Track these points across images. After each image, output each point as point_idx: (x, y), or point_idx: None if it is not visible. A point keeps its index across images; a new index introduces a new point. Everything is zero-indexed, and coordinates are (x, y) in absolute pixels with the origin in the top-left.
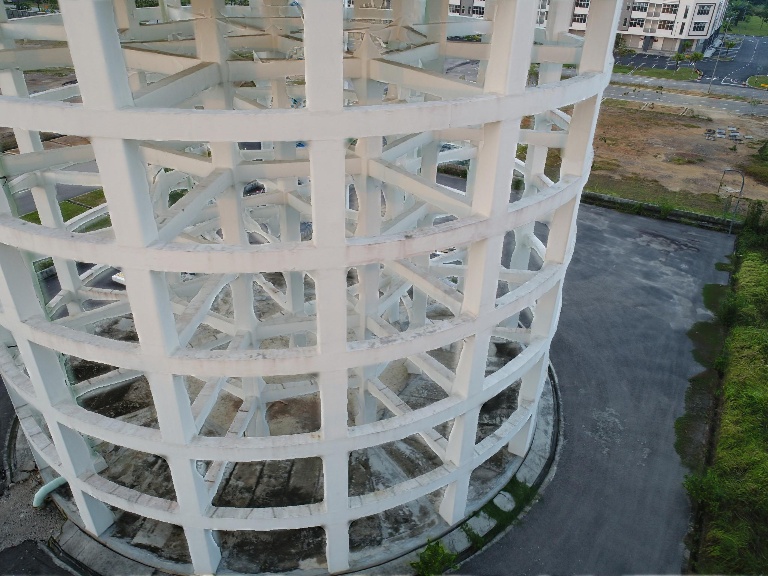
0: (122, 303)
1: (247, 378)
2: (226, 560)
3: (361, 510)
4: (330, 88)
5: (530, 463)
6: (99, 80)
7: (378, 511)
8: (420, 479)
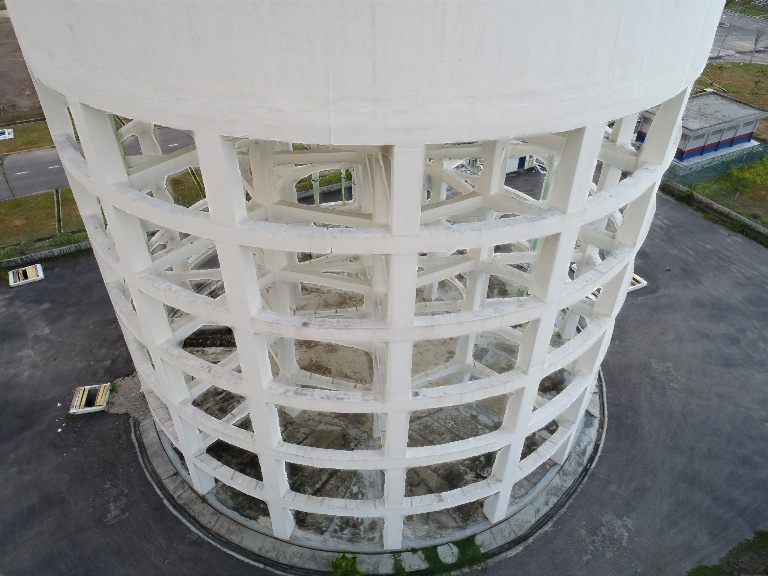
0: None
1: (281, 360)
2: (217, 488)
3: (292, 504)
4: (223, 209)
5: (497, 532)
6: (96, 166)
7: (307, 511)
8: (349, 502)
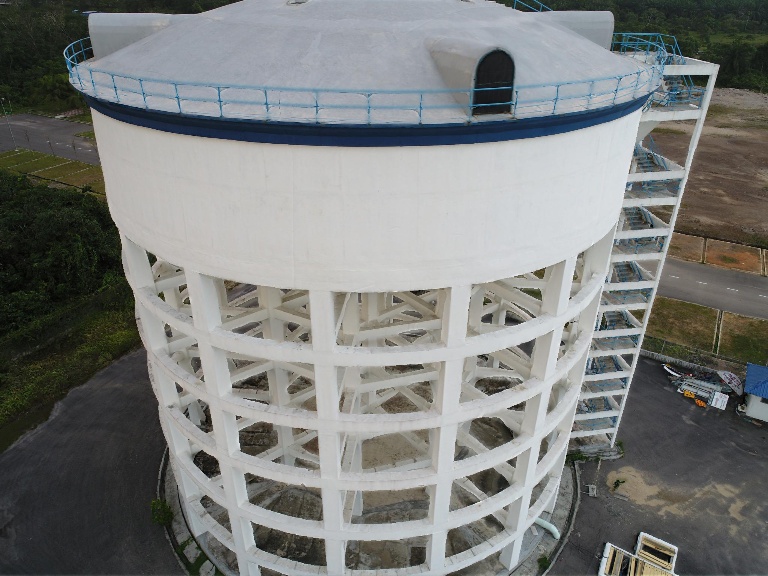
0: (301, 309)
1: None
2: None
3: None
4: None
5: None
6: None
7: None
8: None
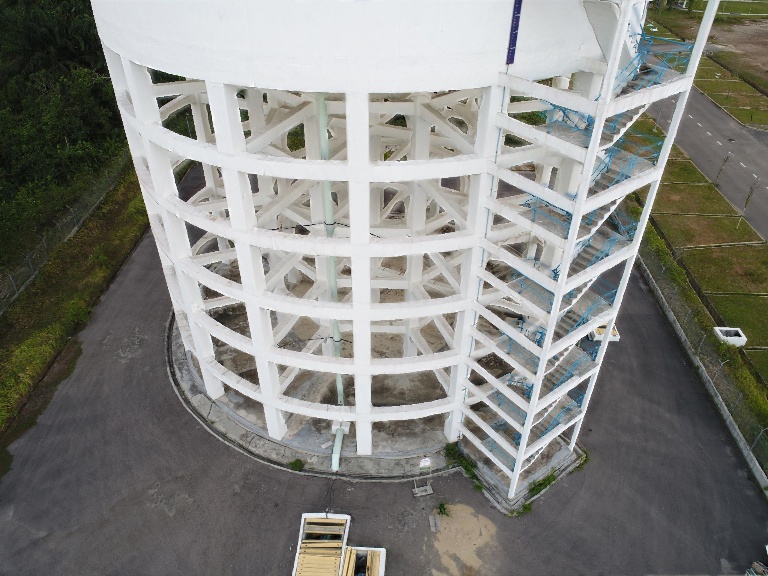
0: None
1: None
2: None
3: None
4: None
5: None
6: None
7: None
8: None
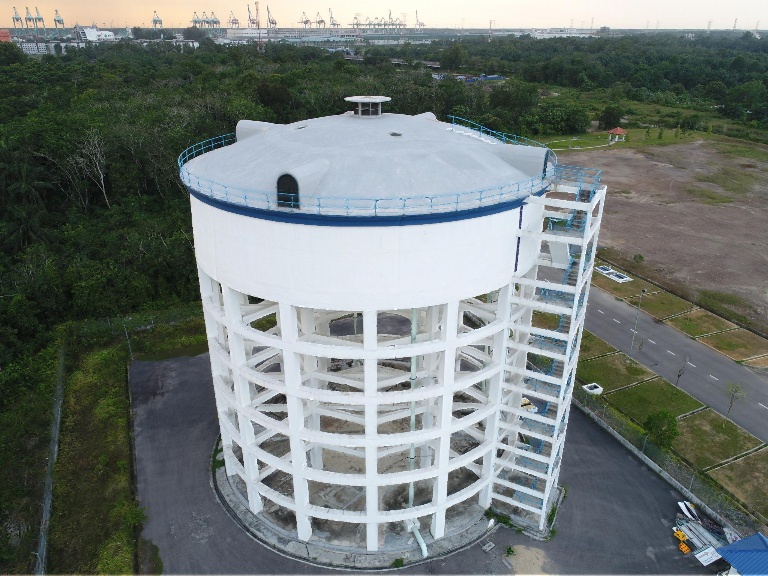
0: None
1: None
2: None
3: None
4: None
5: None
6: None
7: None
8: None
